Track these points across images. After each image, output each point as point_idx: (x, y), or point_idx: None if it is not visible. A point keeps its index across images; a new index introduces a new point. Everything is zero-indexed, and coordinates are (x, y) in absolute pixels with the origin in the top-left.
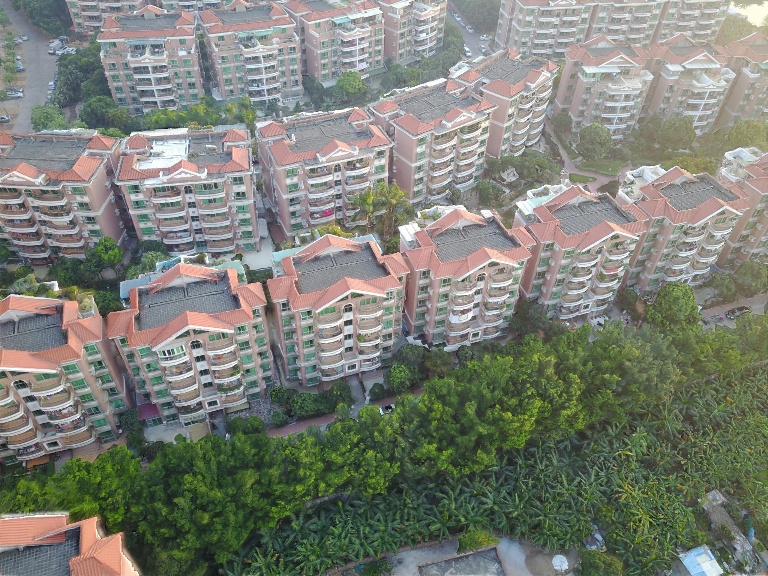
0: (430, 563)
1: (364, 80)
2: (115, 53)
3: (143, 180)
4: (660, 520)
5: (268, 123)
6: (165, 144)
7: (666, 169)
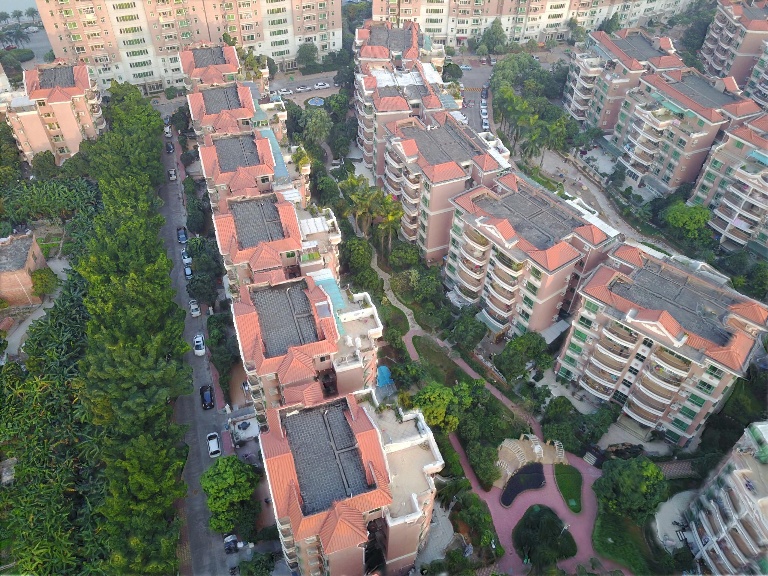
0: (33, 240)
1: (746, 248)
2: (583, 48)
3: (361, 73)
4: (8, 406)
5: (459, 116)
6: (414, 76)
7: (550, 575)
